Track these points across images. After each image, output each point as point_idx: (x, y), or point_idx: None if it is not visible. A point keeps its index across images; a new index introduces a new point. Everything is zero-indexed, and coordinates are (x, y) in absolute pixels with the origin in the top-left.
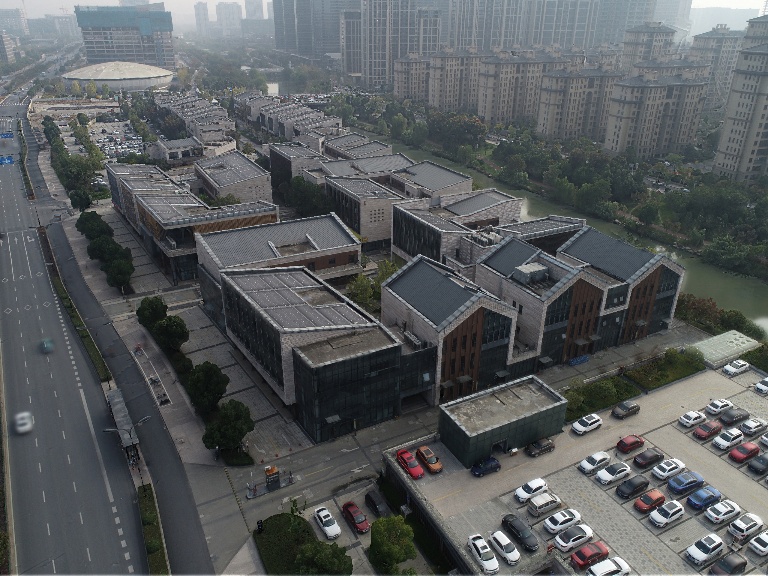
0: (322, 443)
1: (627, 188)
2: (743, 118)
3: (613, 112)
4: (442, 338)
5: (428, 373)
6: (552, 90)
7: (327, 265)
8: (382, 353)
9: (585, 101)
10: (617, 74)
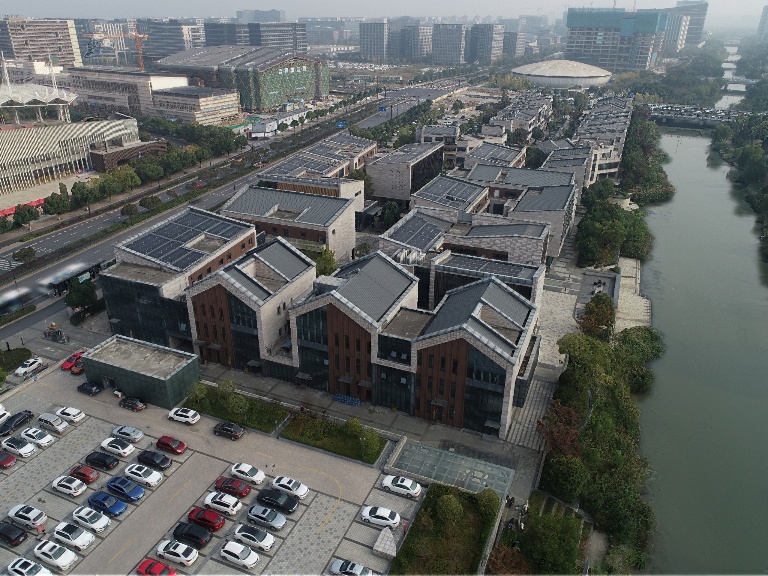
0: None
1: None
2: None
3: None
4: (189, 297)
5: (186, 324)
6: None
7: (299, 236)
8: (145, 286)
9: None
10: None
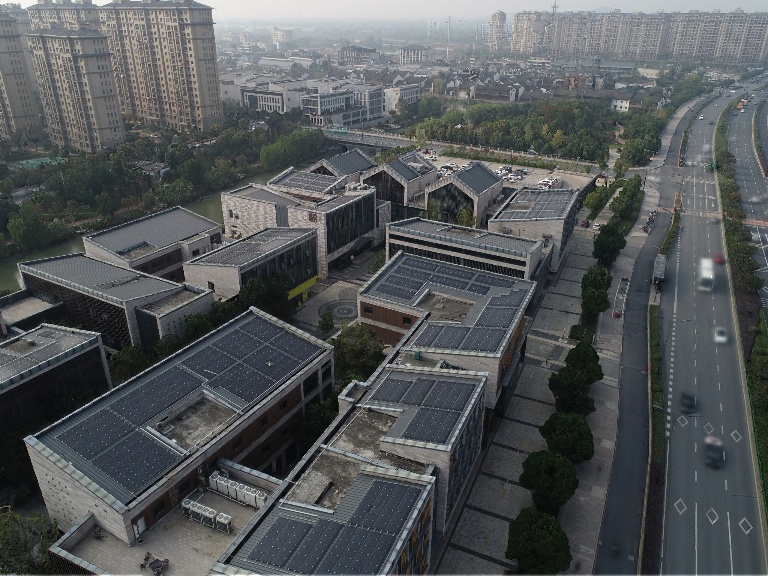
0: None
1: None
2: None
3: None
4: None
5: None
6: None
7: None
8: None
9: None
10: None
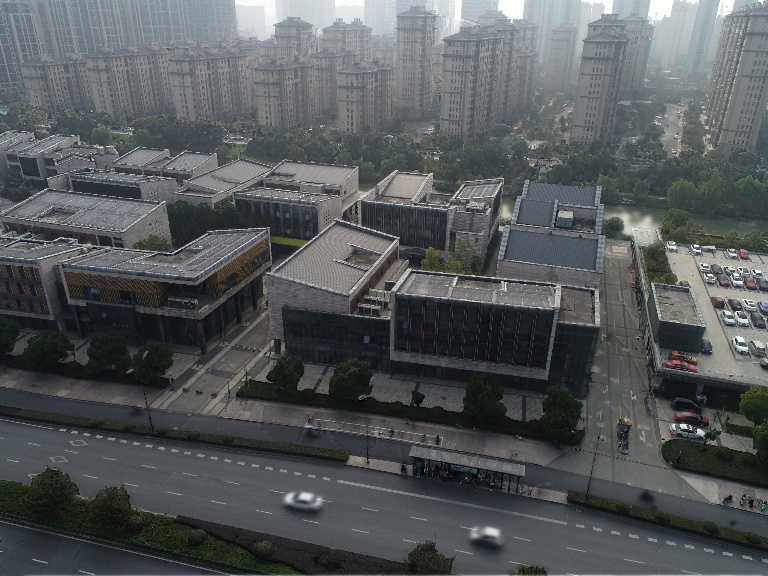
0: (587, 396)
1: (413, 158)
2: (458, 91)
3: (342, 98)
4: None
5: None
6: (270, 83)
7: (387, 267)
8: None
9: (294, 91)
10: (312, 64)
